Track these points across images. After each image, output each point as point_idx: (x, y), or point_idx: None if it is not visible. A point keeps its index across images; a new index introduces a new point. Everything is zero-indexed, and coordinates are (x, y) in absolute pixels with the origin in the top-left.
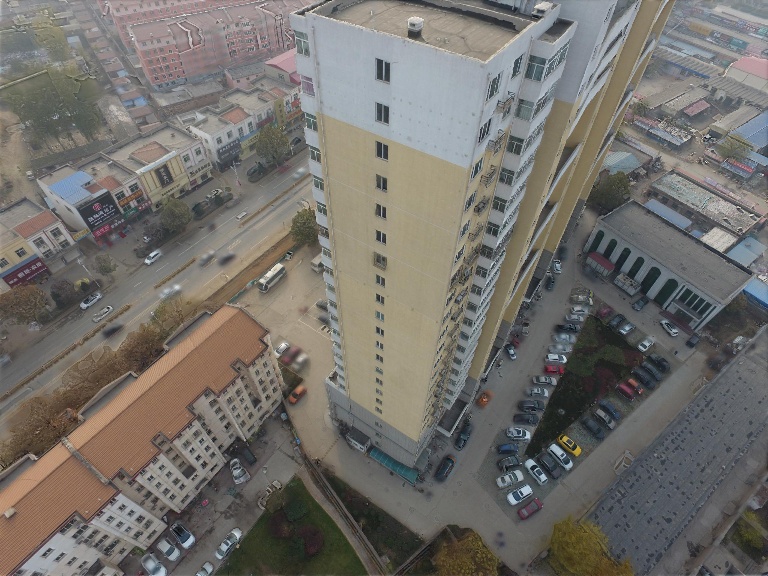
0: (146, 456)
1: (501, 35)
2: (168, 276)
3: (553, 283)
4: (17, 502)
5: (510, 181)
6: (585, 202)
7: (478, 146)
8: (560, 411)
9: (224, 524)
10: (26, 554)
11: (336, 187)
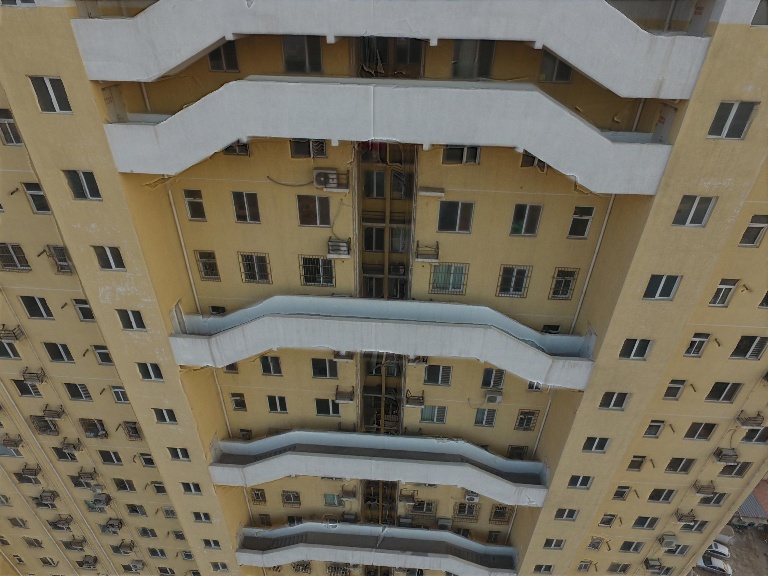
0: None
1: None
2: None
3: None
4: None
5: None
6: None
7: None
8: None
9: None
10: None
11: None
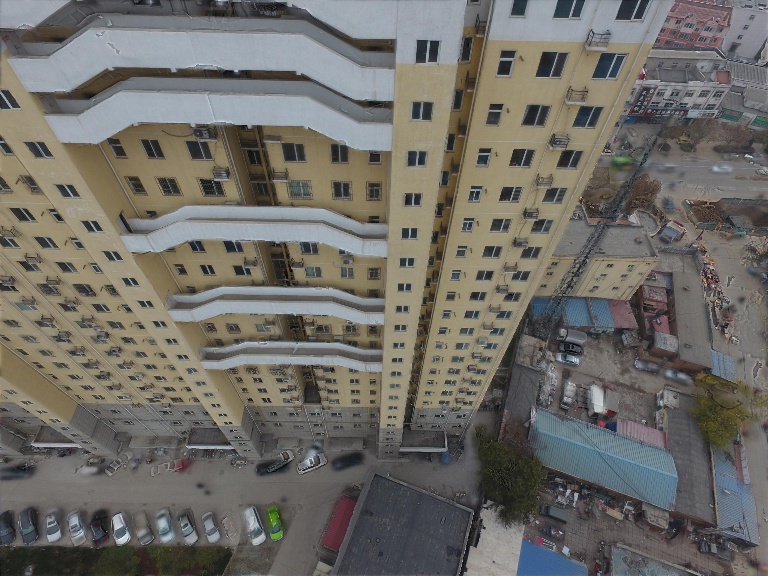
0: None
1: None
2: None
3: (273, 471)
4: None
5: None
6: (400, 433)
7: None
8: (29, 567)
9: None
10: None
11: None
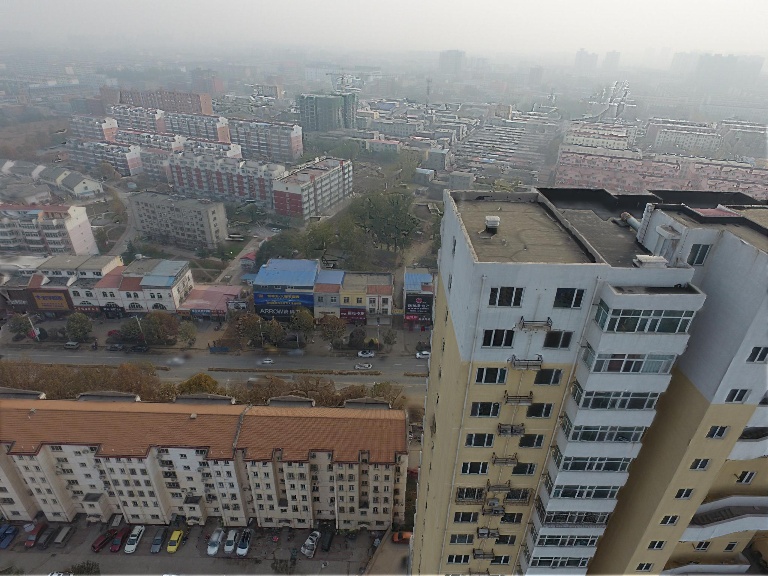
0: (263, 455)
1: (568, 262)
2: (419, 373)
3: None
4: (201, 414)
5: (569, 433)
6: None
7: (485, 348)
8: None
9: (267, 568)
10: (175, 444)
11: (435, 336)
